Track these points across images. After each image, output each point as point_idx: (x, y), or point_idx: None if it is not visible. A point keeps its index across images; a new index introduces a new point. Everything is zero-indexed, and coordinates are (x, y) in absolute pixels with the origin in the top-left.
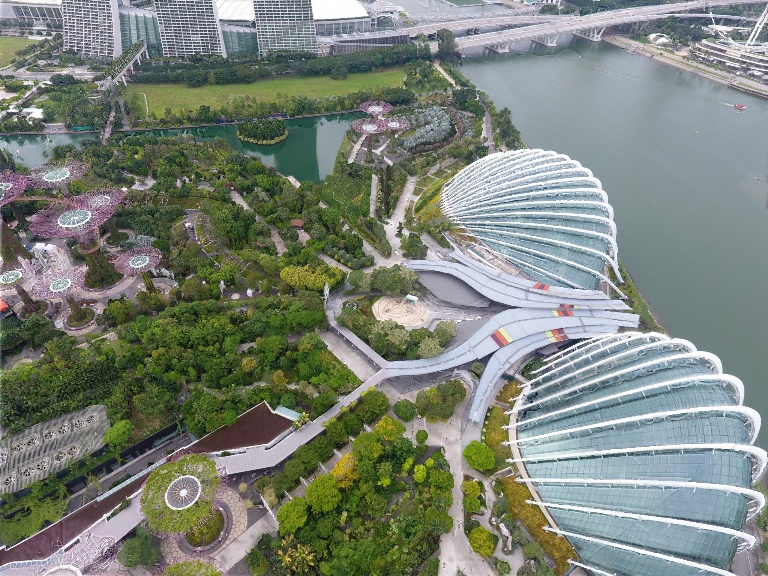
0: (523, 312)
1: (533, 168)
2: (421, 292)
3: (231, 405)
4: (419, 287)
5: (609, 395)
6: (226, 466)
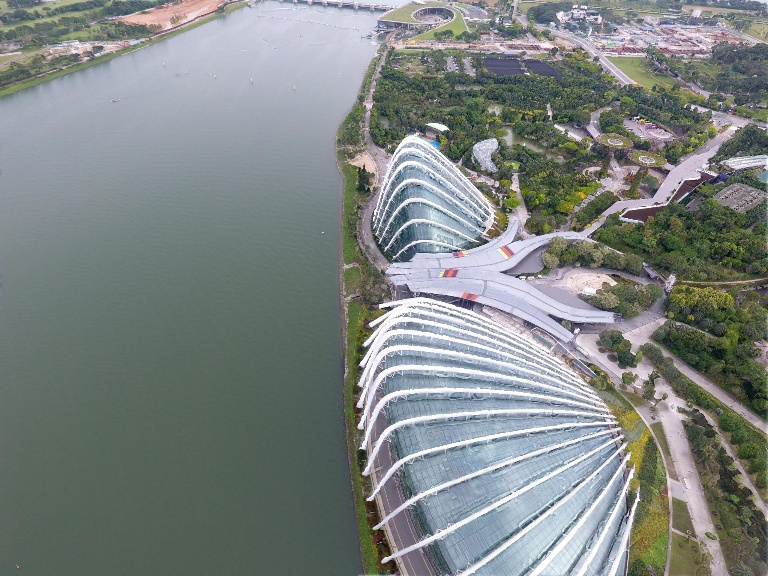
0: (489, 270)
1: (495, 435)
2: (584, 298)
3: (665, 214)
4: (589, 301)
5: None
6: (641, 202)
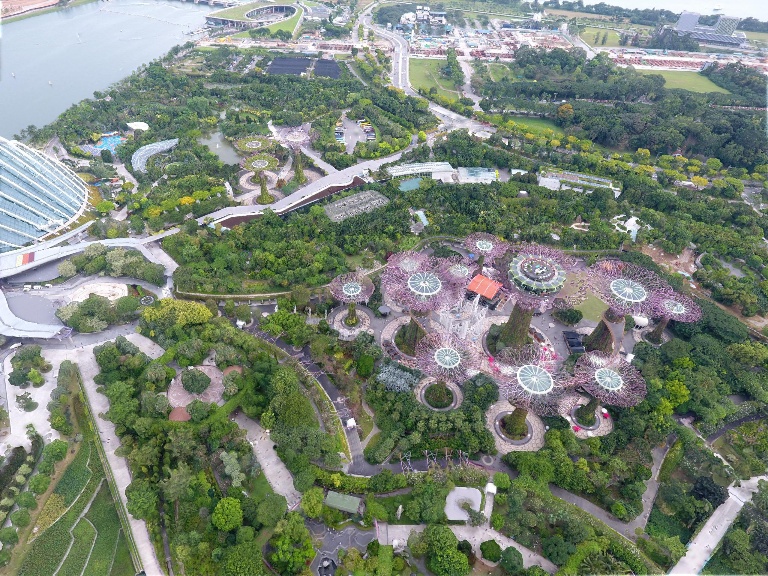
0: None
1: None
2: None
3: None
4: None
5: (3, 185)
6: (255, 208)
